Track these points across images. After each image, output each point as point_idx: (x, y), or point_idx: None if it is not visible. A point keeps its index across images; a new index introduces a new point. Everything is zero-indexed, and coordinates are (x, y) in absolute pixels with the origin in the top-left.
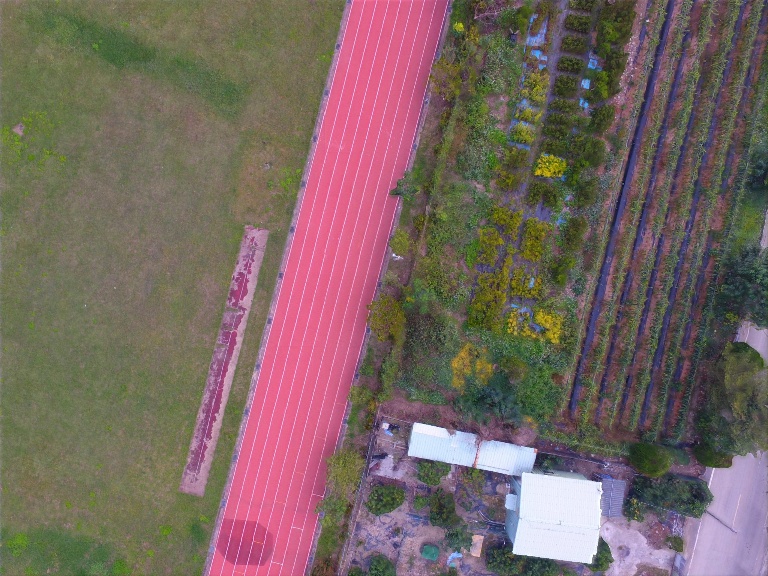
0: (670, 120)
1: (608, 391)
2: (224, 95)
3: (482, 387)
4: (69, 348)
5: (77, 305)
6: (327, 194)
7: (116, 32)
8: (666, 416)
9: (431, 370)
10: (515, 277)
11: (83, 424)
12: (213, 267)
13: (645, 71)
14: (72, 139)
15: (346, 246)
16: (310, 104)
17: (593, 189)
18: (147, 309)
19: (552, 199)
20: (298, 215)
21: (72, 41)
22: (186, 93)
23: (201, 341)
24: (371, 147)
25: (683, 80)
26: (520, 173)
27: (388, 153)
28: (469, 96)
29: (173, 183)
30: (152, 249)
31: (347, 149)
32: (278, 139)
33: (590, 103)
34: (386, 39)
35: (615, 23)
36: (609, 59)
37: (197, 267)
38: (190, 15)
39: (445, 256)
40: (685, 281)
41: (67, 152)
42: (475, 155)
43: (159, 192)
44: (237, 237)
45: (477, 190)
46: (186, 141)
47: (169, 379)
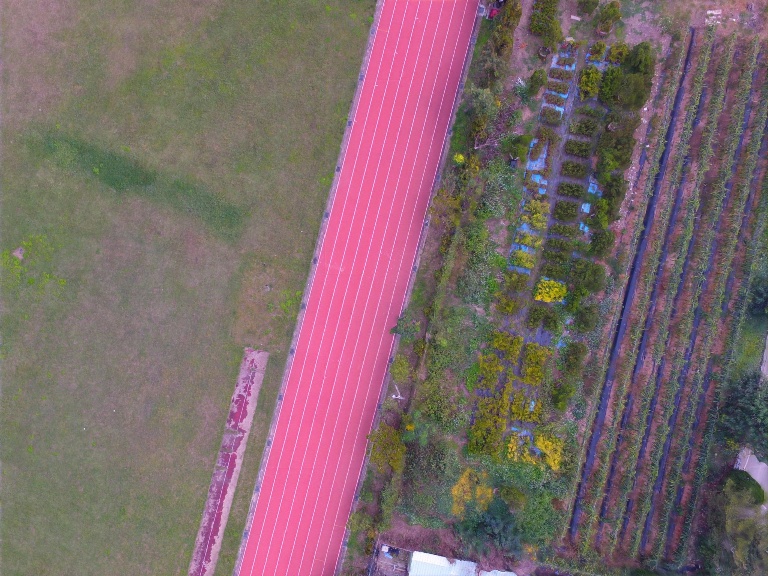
0: (670, 244)
1: (609, 516)
2: (224, 218)
3: (482, 514)
4: (68, 471)
5: (76, 428)
6: (327, 316)
7: (117, 156)
8: (667, 539)
9: (431, 498)
10: (515, 402)
11: (81, 548)
12: (213, 389)
13: (645, 199)
14: (72, 262)
15: (346, 368)
16: (310, 226)
17: (593, 316)
18: (146, 432)
19: (552, 325)
20: (298, 337)
21: (72, 165)
22: (186, 216)
23: (200, 463)
24: (371, 269)
25: (683, 205)
26: (520, 299)
27: (388, 275)
28: (469, 222)
29: (173, 306)
30: (152, 372)
31: (347, 271)
32: (278, 261)
33: (590, 227)
34: (386, 162)
35: (615, 152)
36: (609, 185)
37: (197, 389)
38: (191, 139)
39: (445, 380)
40: (686, 406)
41: (67, 275)
42: (475, 280)
43: (159, 315)
44: (237, 359)
45: (477, 314)
46: (186, 264)
47: (168, 502)
